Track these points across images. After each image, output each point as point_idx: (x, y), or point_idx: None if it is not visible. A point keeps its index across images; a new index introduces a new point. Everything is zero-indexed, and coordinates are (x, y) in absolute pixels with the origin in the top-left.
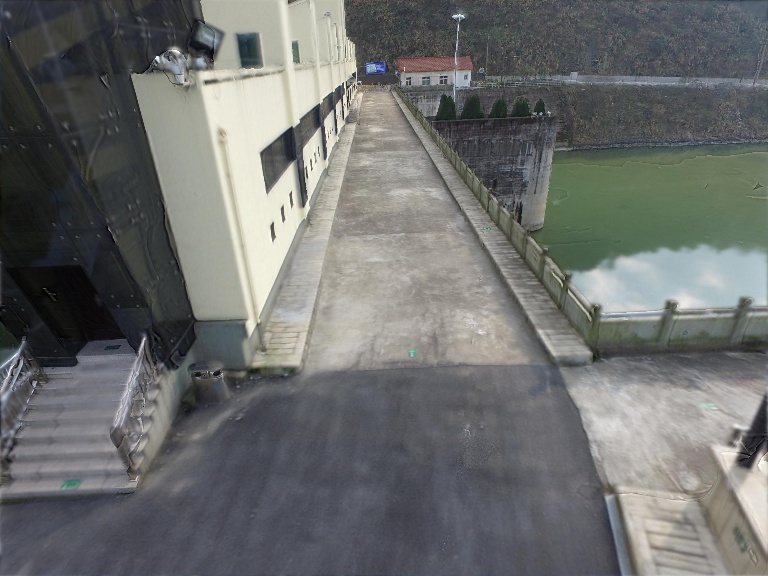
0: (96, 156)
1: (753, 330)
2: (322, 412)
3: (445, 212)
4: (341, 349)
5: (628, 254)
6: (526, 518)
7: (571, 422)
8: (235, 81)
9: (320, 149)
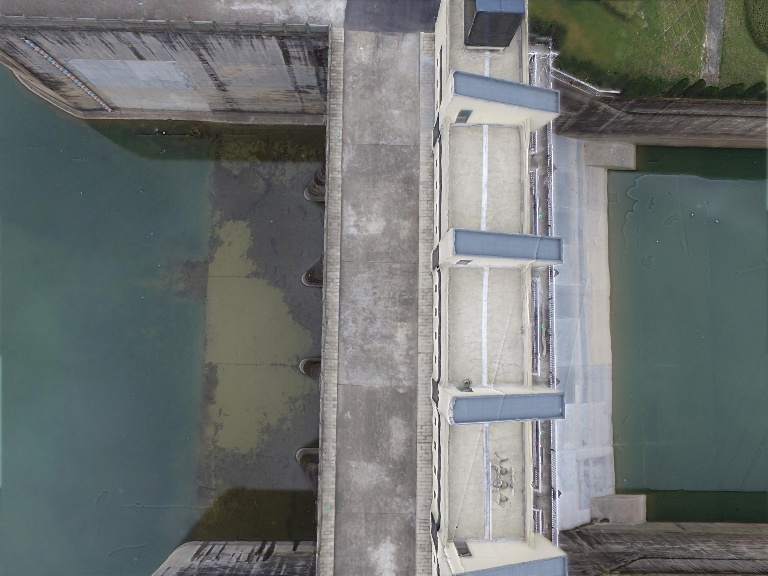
0: None
1: None
2: (412, 17)
3: (352, 177)
4: (409, 44)
5: (110, 464)
6: None
7: (349, 7)
8: (446, 6)
9: None
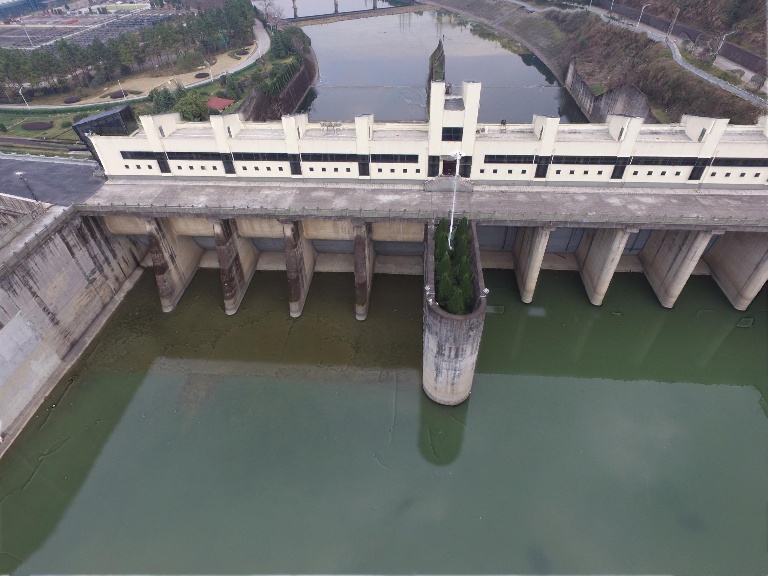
0: (88, 140)
1: (56, 224)
2: None
3: None
4: None
5: (350, 454)
6: (59, 199)
7: (66, 205)
8: (105, 138)
9: (221, 168)
